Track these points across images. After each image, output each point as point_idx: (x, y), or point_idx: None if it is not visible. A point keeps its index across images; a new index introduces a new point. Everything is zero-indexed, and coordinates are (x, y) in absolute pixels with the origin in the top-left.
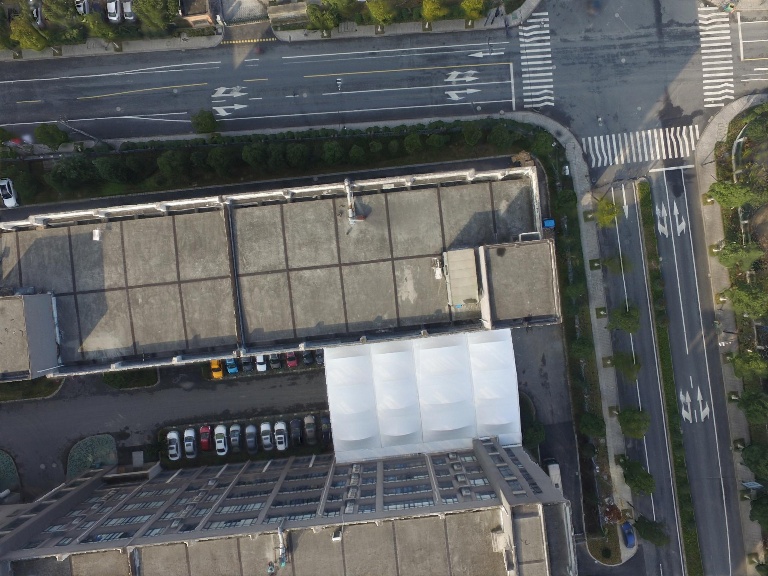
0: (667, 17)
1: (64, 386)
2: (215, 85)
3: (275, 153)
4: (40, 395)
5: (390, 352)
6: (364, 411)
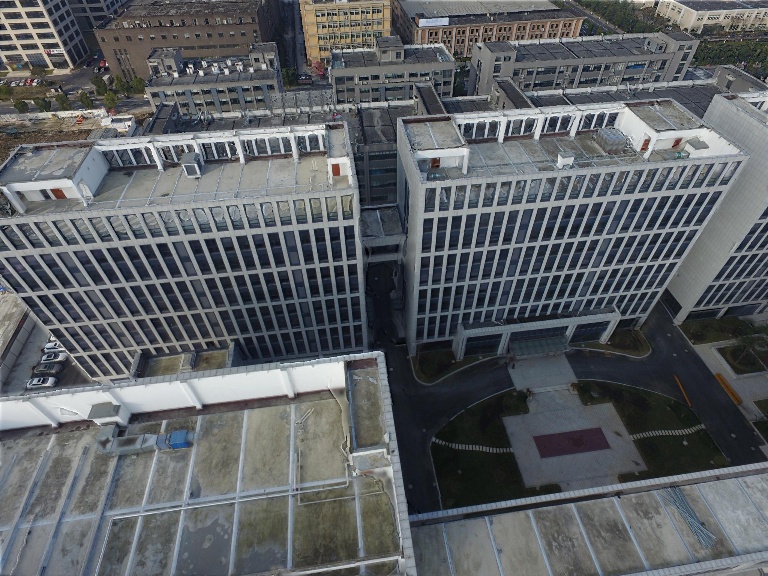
0: None
1: None
2: None
3: None
4: None
5: None
6: None
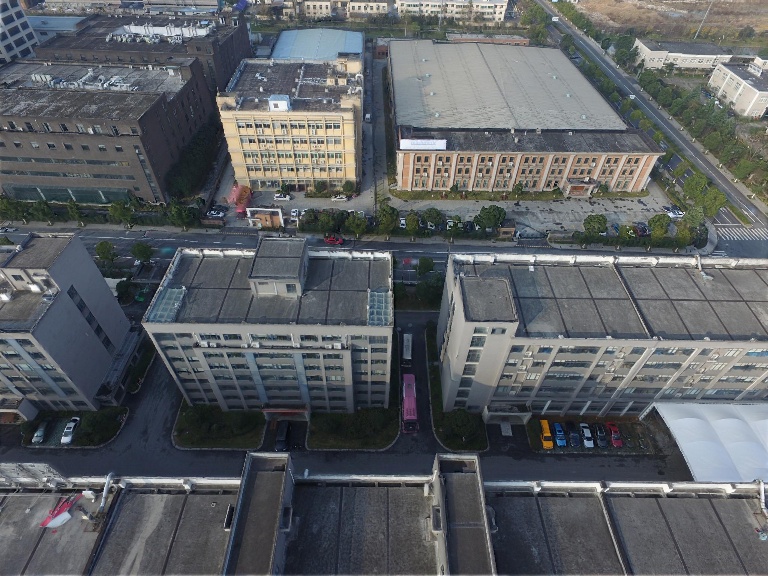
0: None
1: (398, 442)
2: None
3: None
4: (374, 447)
5: (729, 417)
6: (728, 468)
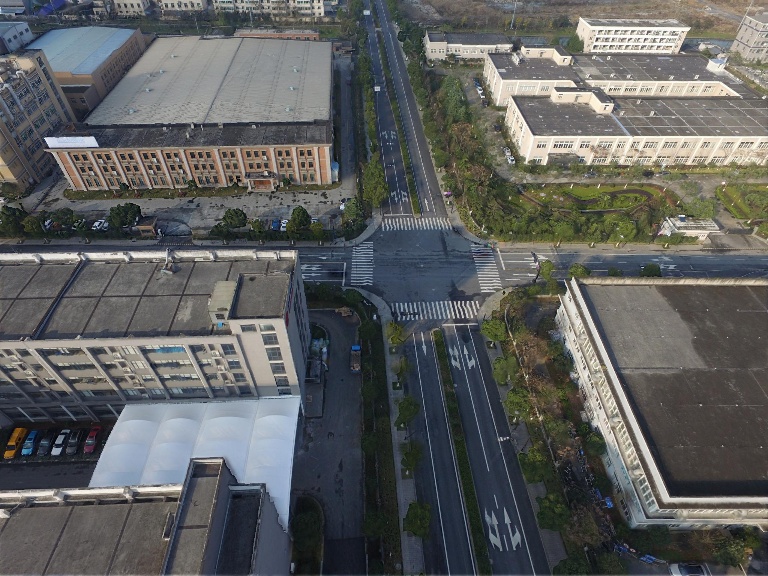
0: (451, 248)
1: None
2: None
3: None
4: None
5: (178, 417)
6: (127, 472)
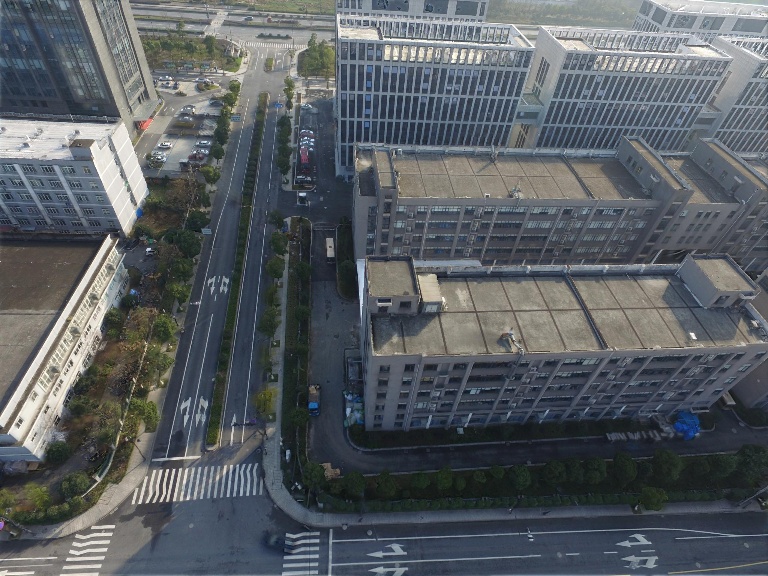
0: None
1: None
2: (659, 571)
3: (576, 465)
4: None
5: None
6: None
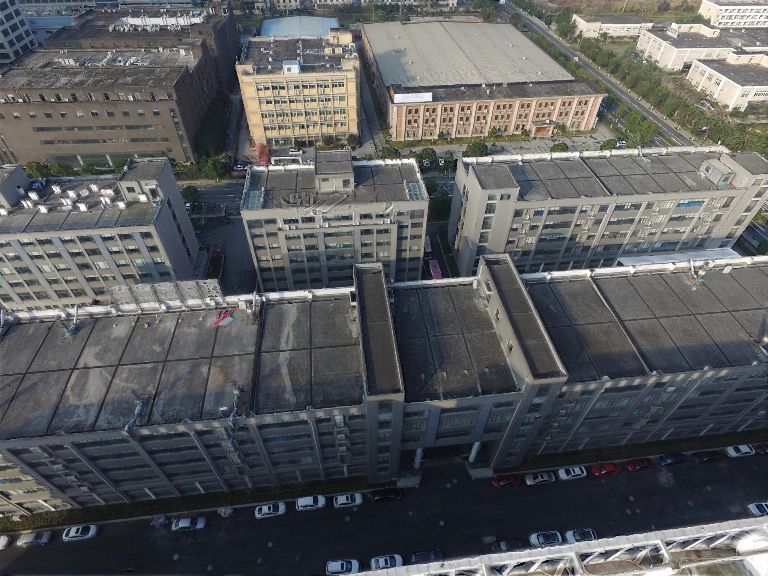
0: None
1: None
2: None
3: None
4: None
5: (672, 259)
6: None
